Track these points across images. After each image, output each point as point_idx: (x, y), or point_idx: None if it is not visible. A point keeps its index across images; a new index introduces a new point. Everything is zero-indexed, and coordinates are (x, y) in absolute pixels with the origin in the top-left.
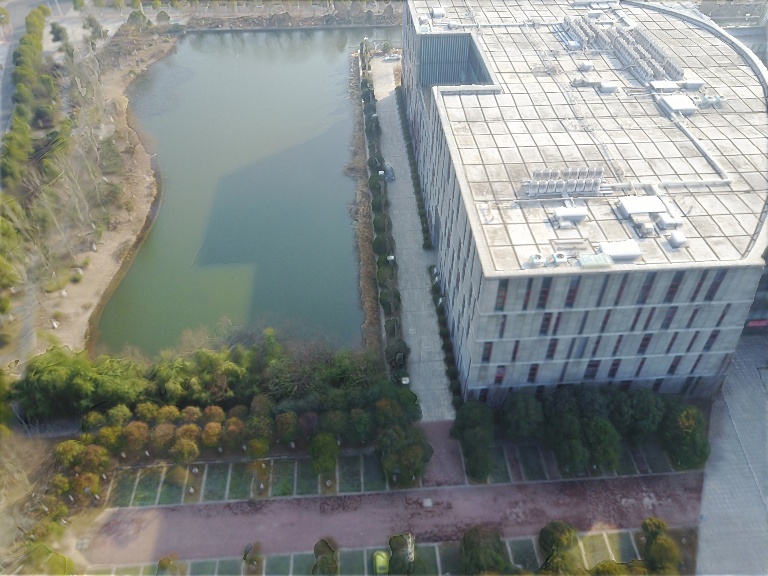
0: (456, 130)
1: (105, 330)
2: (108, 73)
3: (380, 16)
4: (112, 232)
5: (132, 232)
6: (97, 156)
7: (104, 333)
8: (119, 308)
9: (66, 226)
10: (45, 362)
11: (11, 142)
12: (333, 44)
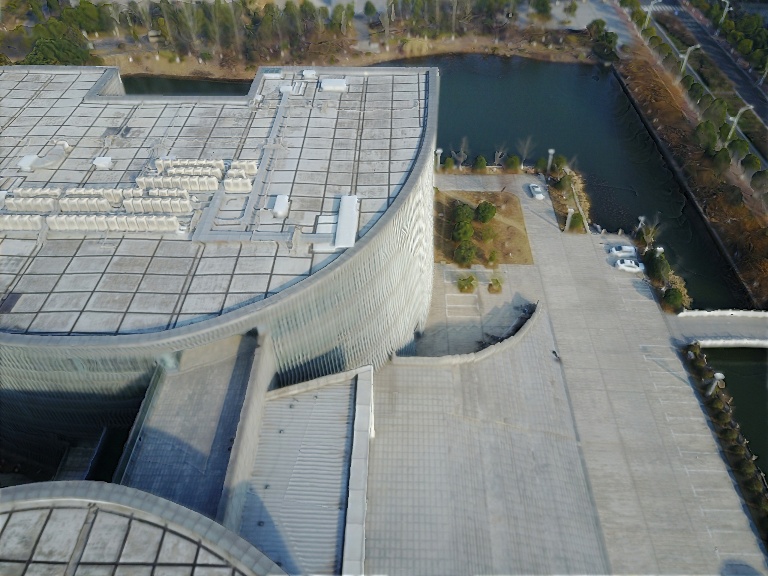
0: (36, 75)
1: (130, 81)
2: (487, 39)
3: (716, 190)
4: (219, 66)
5: (223, 75)
6: (278, 33)
7: (127, 80)
8: (148, 83)
9: (176, 28)
10: (56, 40)
11: (304, 5)
12: (667, 179)
